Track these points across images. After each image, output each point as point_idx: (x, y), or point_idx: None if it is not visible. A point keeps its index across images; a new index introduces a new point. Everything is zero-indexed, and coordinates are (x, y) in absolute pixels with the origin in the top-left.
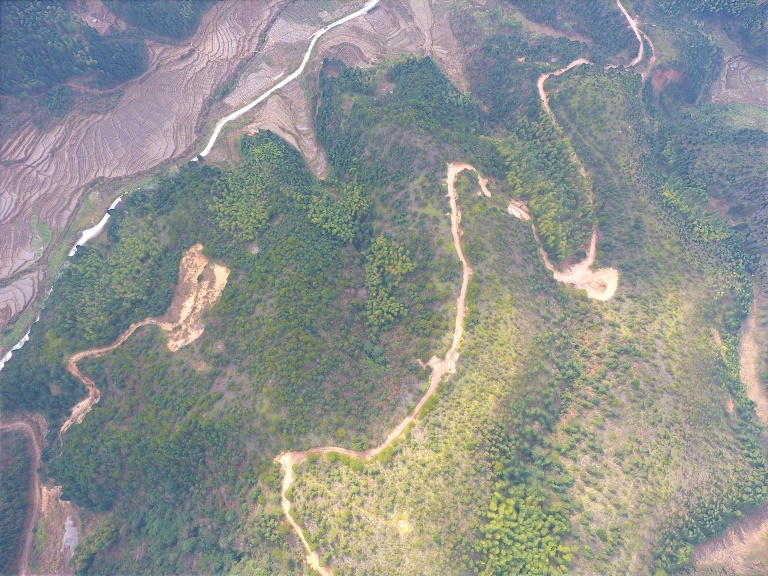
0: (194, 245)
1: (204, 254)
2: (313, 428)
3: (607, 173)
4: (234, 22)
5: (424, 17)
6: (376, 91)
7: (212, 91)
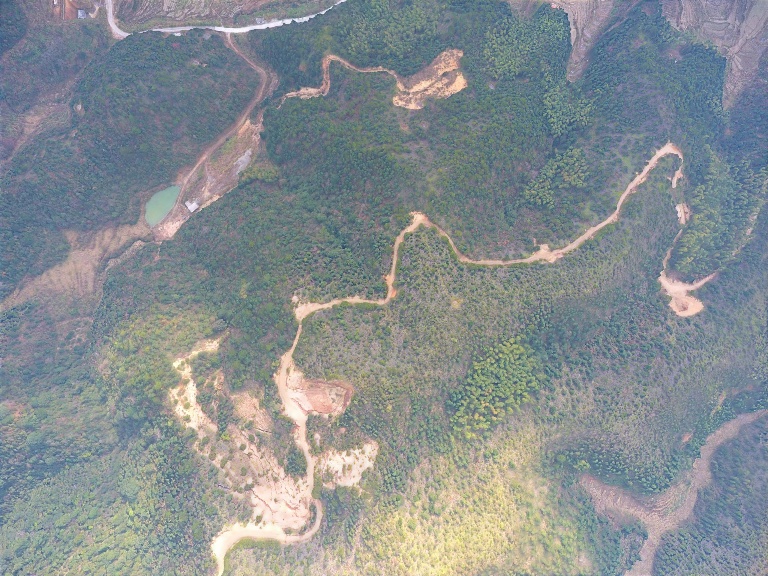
0: (458, 49)
1: (462, 60)
2: (447, 215)
3: (765, 246)
4: None
5: (752, 26)
6: (665, 51)
7: None
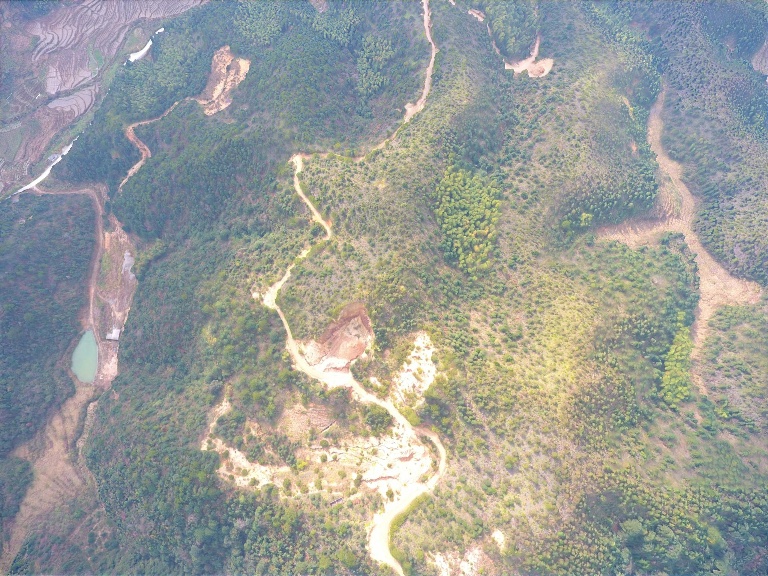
0: (223, 46)
1: (231, 49)
2: (317, 140)
3: None
4: None
5: None
6: None
7: None
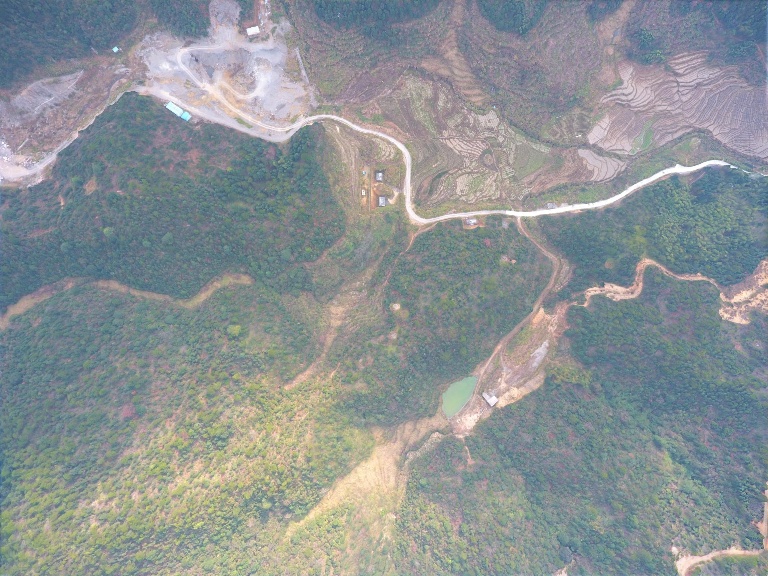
0: None
1: None
2: None
3: None
4: None
5: None
6: None
7: None
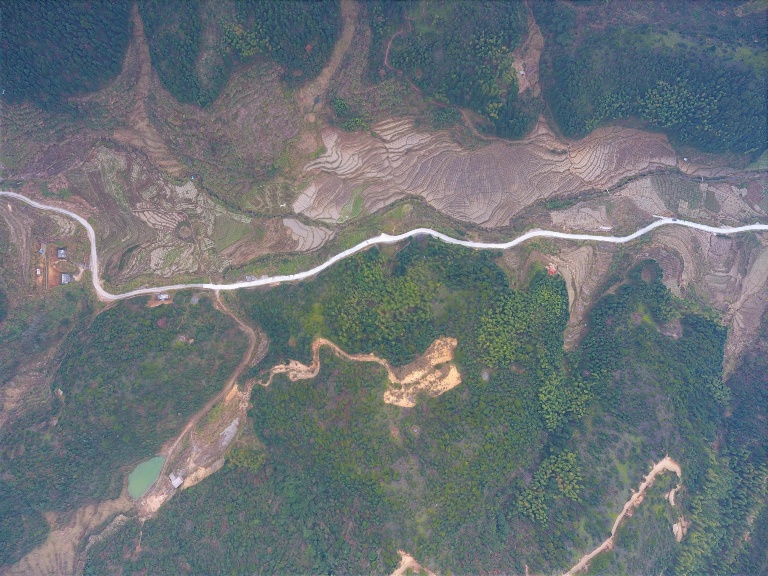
0: (452, 338)
1: (455, 356)
2: (437, 557)
3: (763, 557)
4: (614, 152)
5: (755, 282)
6: None
7: (549, 196)
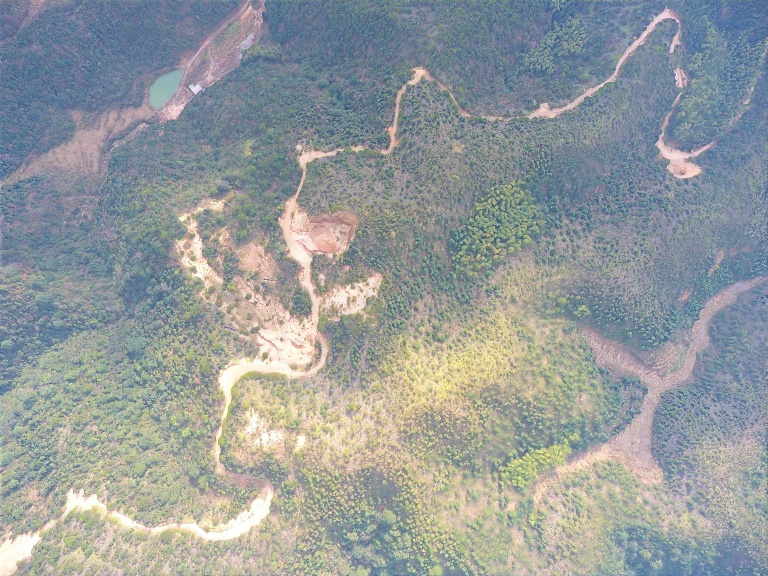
0: None
1: None
2: (448, 70)
3: (761, 113)
4: None
5: None
6: None
7: None
